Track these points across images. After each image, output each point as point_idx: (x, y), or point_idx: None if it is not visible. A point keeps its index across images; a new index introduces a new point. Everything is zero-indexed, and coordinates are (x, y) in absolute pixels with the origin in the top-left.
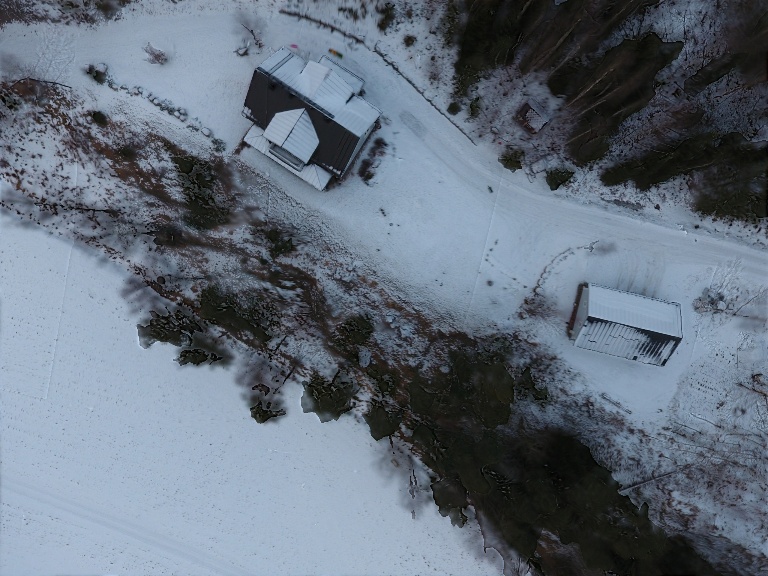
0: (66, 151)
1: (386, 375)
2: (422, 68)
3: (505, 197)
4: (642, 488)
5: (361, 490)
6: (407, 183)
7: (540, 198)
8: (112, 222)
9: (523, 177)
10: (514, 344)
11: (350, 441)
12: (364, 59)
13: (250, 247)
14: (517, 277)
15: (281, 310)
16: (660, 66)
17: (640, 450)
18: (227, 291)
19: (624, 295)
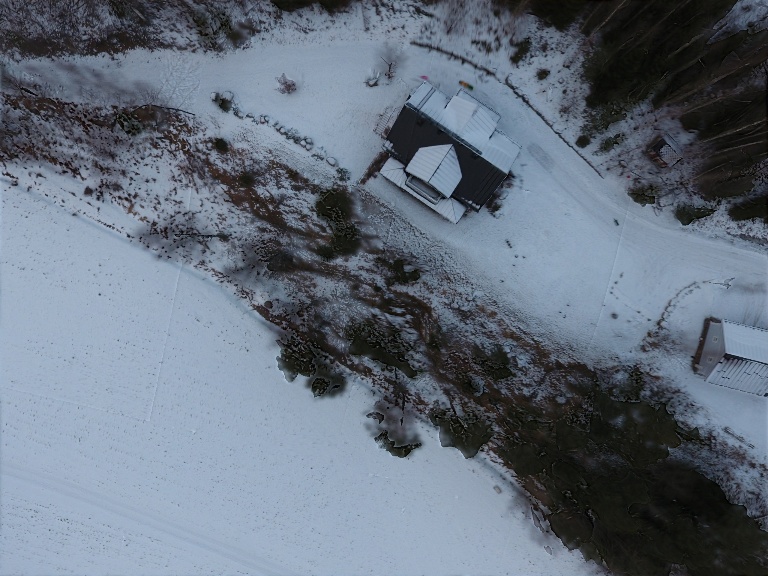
0: (181, 176)
1: None
2: (553, 101)
3: (631, 230)
4: (760, 522)
5: (462, 516)
6: (534, 215)
7: (666, 232)
8: (222, 246)
9: (649, 210)
10: (634, 376)
11: (452, 467)
12: (494, 91)
13: (364, 274)
14: (641, 310)
15: (388, 336)
16: None
17: (760, 484)
18: (333, 316)
19: (758, 332)
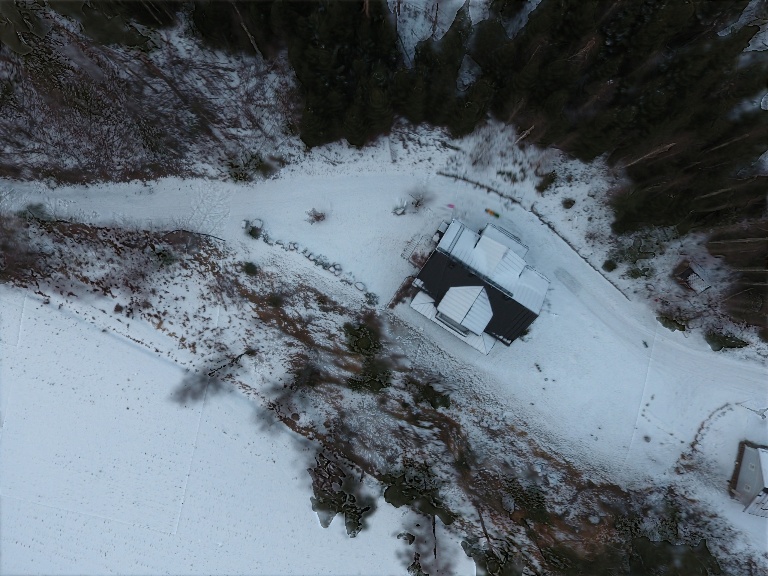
0: (210, 294)
1: (528, 519)
2: (578, 228)
3: (660, 352)
4: None
5: None
6: (562, 339)
7: (696, 353)
8: (249, 360)
9: (678, 332)
10: (669, 498)
11: None
12: (520, 218)
13: (392, 391)
14: (674, 432)
15: (416, 447)
16: None
17: None
18: (360, 427)
19: None
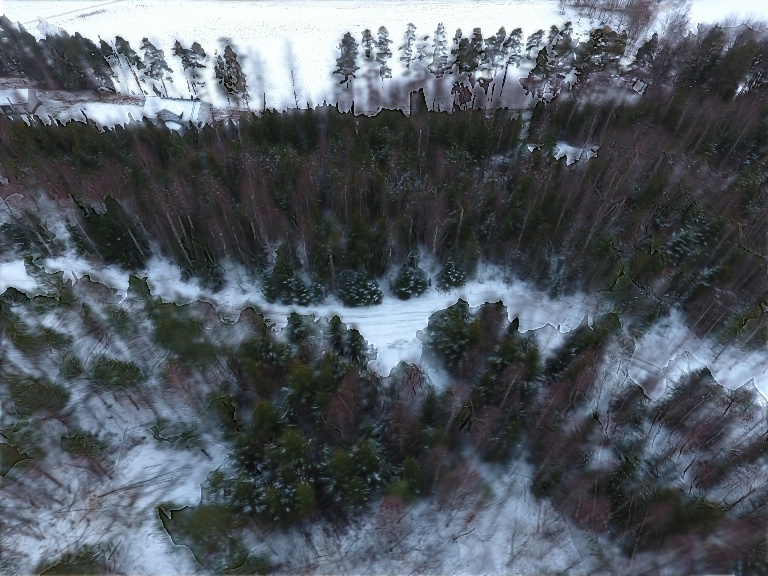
0: None
1: None
2: None
3: None
4: None
5: None
6: None
7: None
8: None
9: None
10: None
11: None
12: None
13: None
14: None
15: None
16: None
17: None
18: None
19: (8, 102)
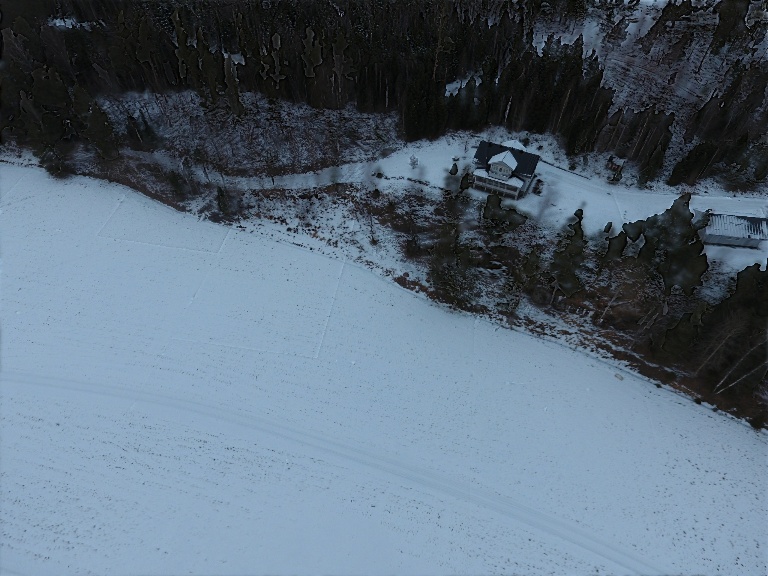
0: (349, 215)
1: (586, 301)
2: (549, 156)
3: (619, 196)
4: None
5: (599, 405)
6: (561, 194)
7: (638, 194)
8: (372, 248)
9: (623, 189)
10: None
11: (574, 366)
12: None
13: None
14: None
15: (493, 283)
16: (669, 120)
17: None
18: (451, 279)
19: None
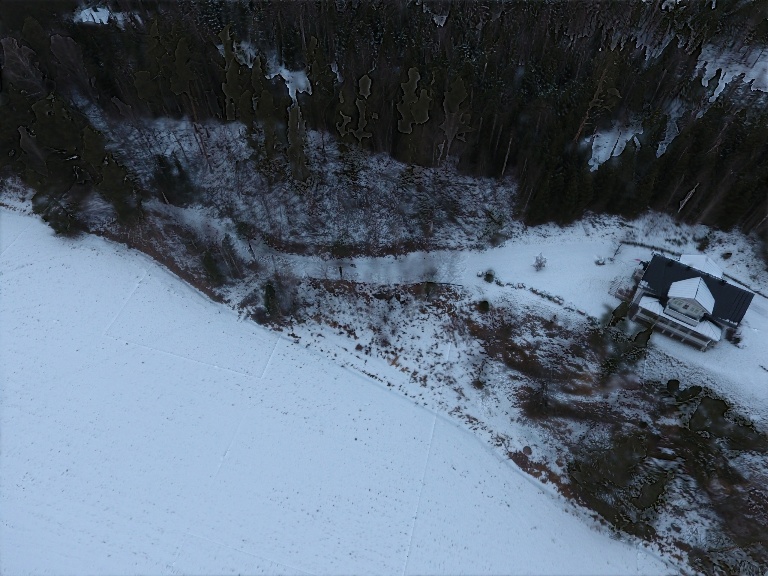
0: (443, 333)
1: None
2: (742, 272)
3: None
4: None
5: None
6: None
7: None
8: (476, 393)
9: None
10: None
11: None
12: None
13: (626, 410)
14: None
15: None
16: None
17: None
18: None
19: None
